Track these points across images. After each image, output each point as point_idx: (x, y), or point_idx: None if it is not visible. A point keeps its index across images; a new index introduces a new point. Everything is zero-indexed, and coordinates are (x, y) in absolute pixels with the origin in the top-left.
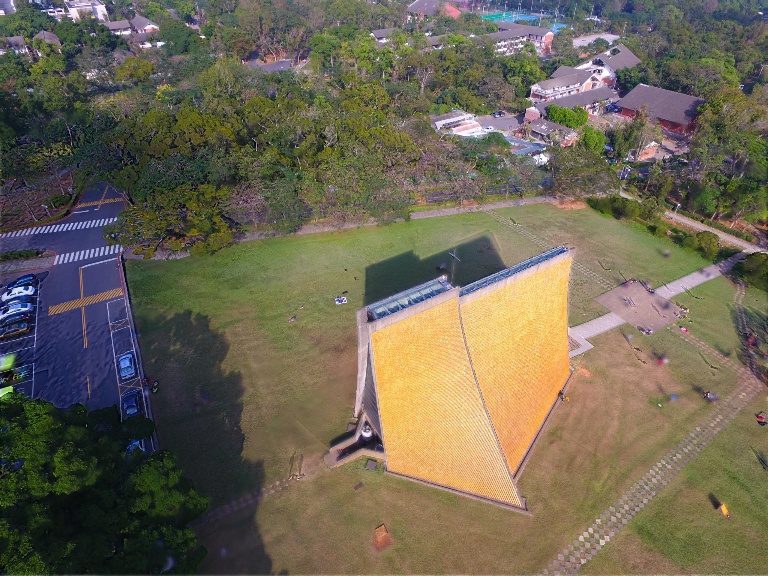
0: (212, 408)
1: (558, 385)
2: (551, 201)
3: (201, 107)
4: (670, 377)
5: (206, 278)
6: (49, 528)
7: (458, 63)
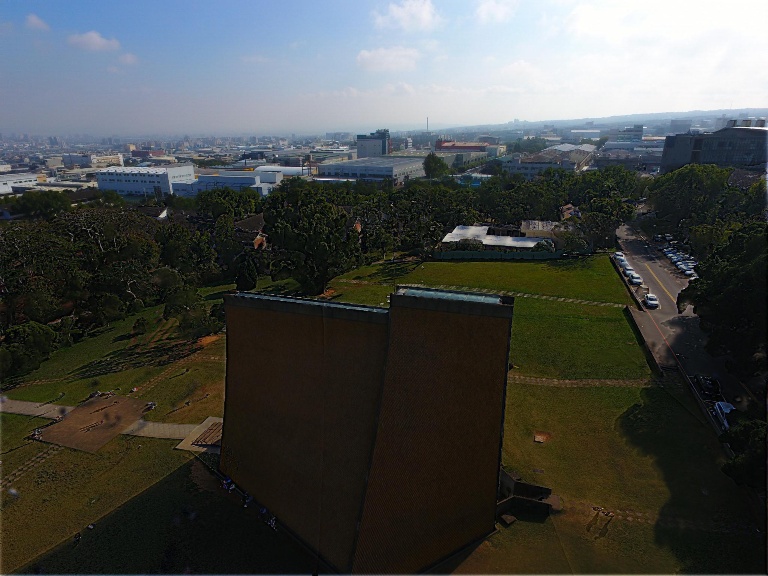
0: None
1: None
2: None
3: None
4: (218, 382)
5: None
6: None
7: None
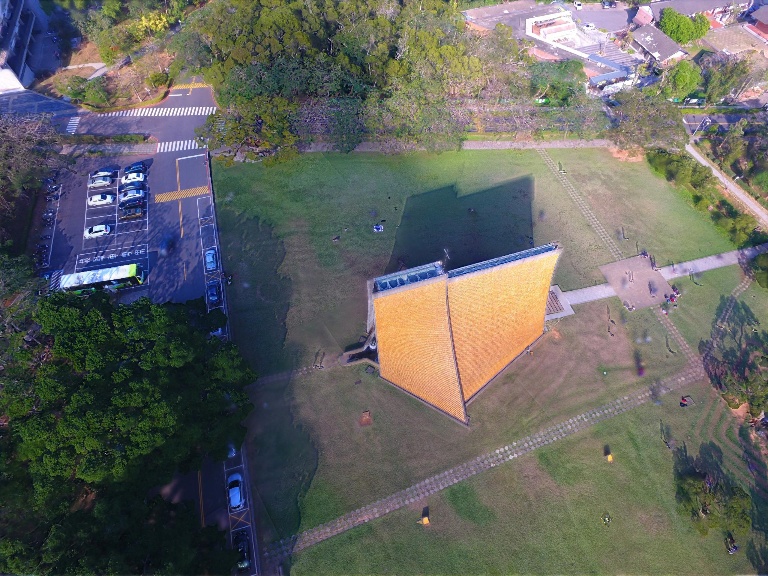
0: (267, 305)
1: (527, 342)
2: (610, 147)
3: None
4: (628, 352)
5: (273, 187)
6: (168, 385)
7: None
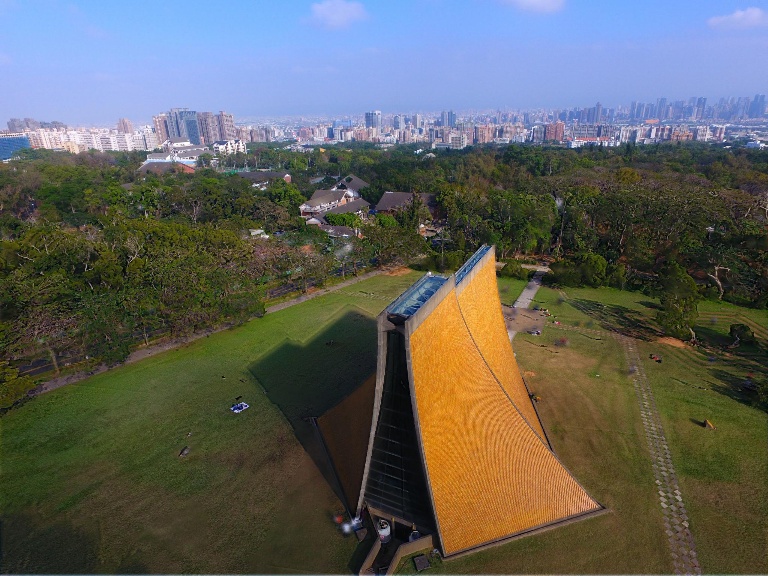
0: None
1: (525, 388)
2: (382, 273)
3: None
4: (582, 355)
5: None
6: None
7: (223, 197)
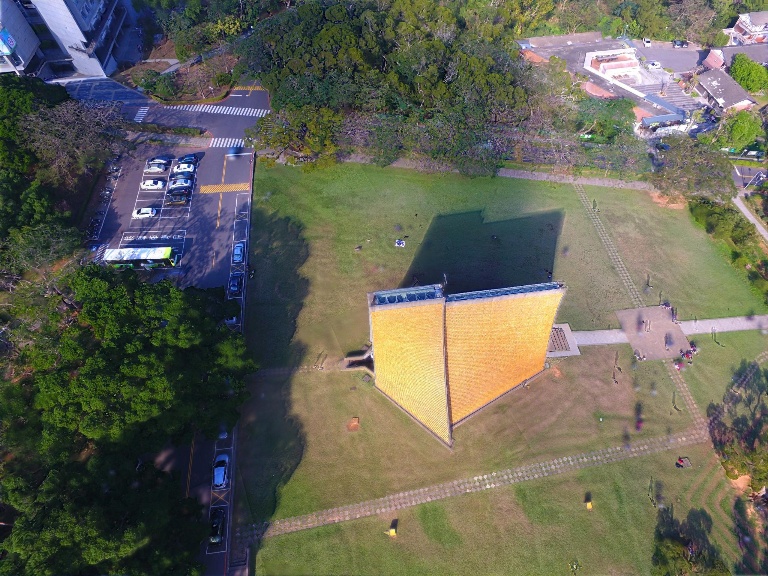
0: (282, 302)
1: (525, 375)
2: (651, 191)
3: (352, 0)
4: (629, 402)
5: (309, 191)
6: (173, 362)
7: None
